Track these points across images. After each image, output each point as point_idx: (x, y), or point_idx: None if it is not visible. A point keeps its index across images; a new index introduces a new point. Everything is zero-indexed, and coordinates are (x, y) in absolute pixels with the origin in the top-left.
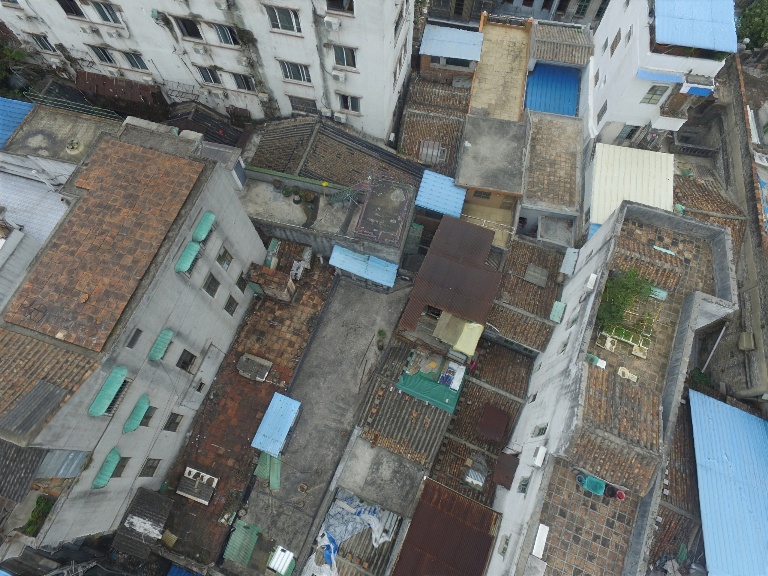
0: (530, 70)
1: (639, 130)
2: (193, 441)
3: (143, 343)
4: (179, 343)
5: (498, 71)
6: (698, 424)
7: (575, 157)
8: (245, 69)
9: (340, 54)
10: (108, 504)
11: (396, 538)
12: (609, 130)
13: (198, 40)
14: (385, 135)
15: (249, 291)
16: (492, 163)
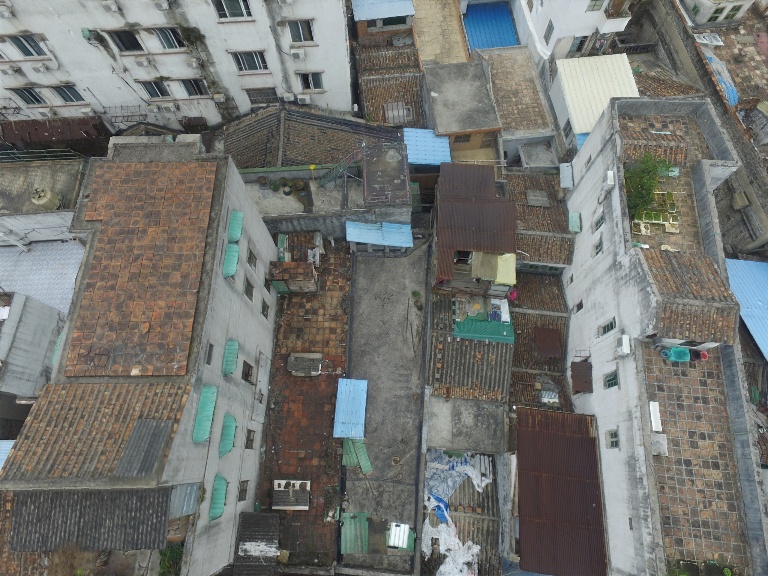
0: (463, 13)
1: (587, 40)
2: (270, 454)
3: (216, 358)
4: (239, 354)
5: (432, 22)
6: None
7: (533, 82)
8: (195, 72)
9: (295, 30)
10: (222, 536)
11: (496, 477)
12: (560, 47)
13: (138, 52)
14: (350, 107)
15: (273, 292)
16: (463, 106)
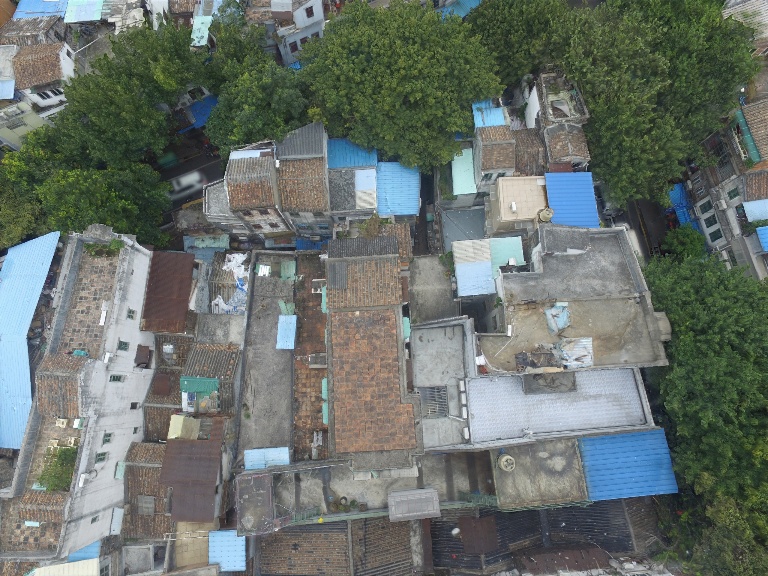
0: None
1: None
2: None
3: None
4: None
5: None
6: None
7: None
8: None
9: None
10: None
11: (210, 304)
12: None
13: None
14: None
15: None
16: None
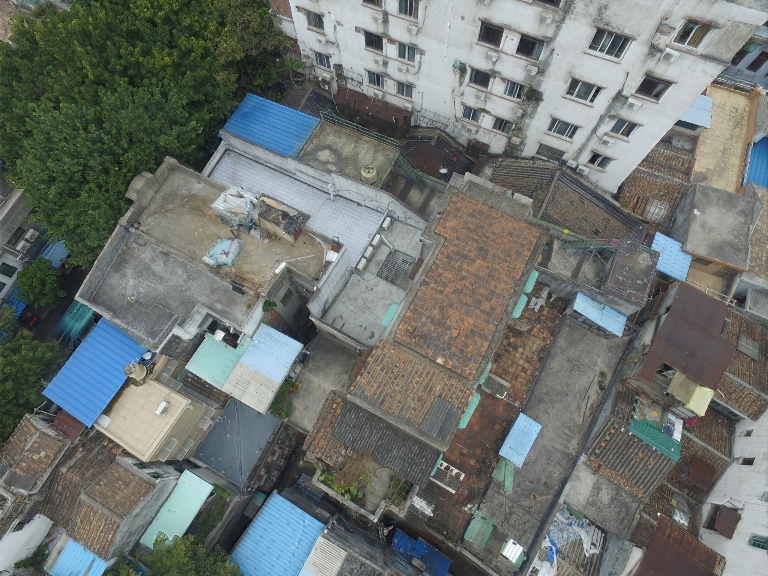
0: (754, 142)
1: None
2: None
3: None
4: None
5: (718, 136)
6: None
7: None
8: (512, 117)
9: (619, 125)
10: None
11: (604, 552)
12: None
13: (482, 88)
14: None
15: None
16: (719, 235)
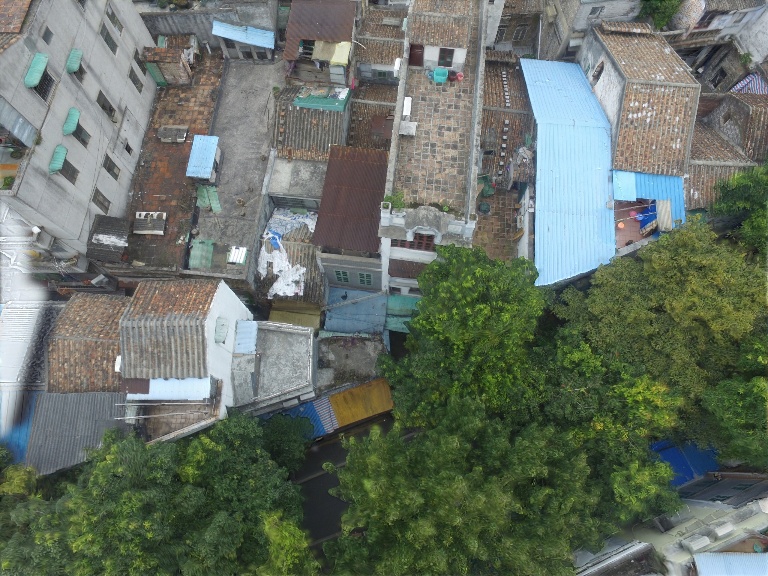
0: None
1: None
2: (136, 197)
3: (57, 48)
4: (93, 78)
5: None
6: (527, 70)
7: None
8: None
9: None
10: (70, 207)
11: None
12: None
13: None
14: None
15: (150, 79)
16: None
